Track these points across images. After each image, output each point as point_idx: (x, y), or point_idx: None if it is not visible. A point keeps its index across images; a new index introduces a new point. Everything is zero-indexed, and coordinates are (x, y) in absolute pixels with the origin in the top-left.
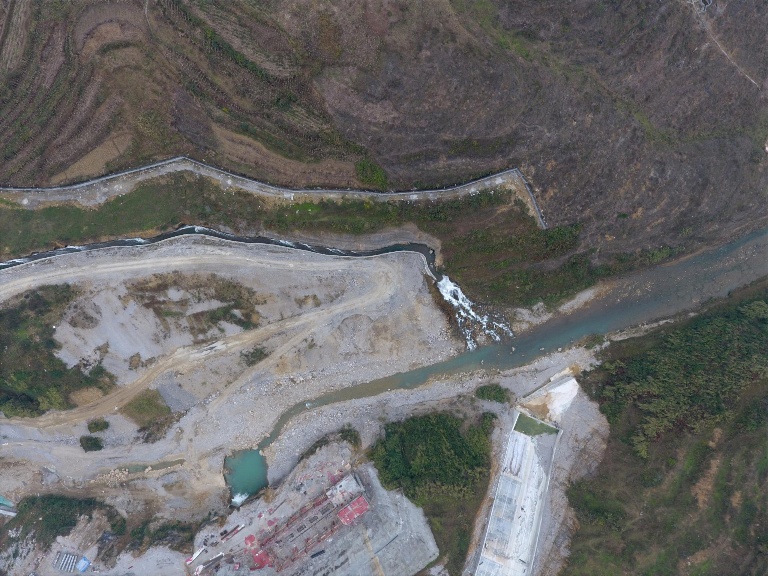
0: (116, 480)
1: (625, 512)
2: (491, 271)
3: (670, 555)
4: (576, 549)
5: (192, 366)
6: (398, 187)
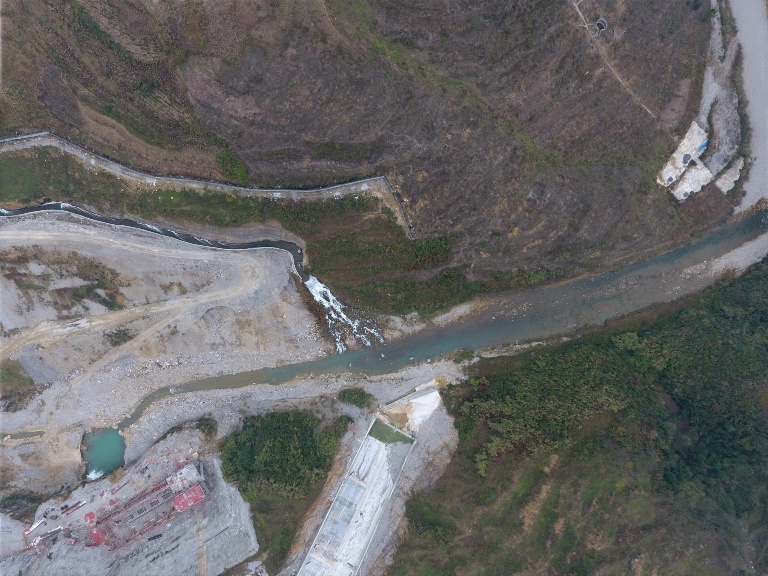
0: None
1: (456, 527)
2: (360, 276)
3: (489, 574)
4: (400, 559)
5: (54, 341)
6: (261, 183)
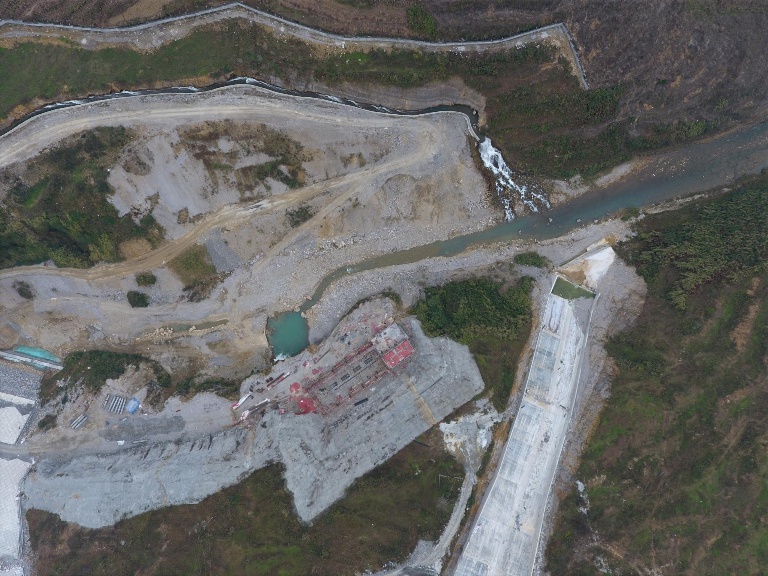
0: (161, 338)
1: (664, 359)
2: (532, 135)
3: (709, 395)
4: (617, 391)
5: (238, 223)
6: (447, 37)
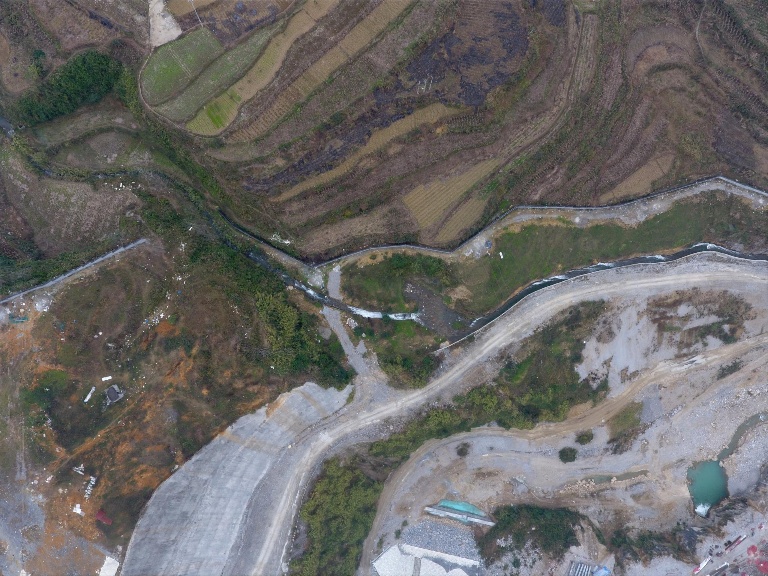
0: (585, 490)
1: None
2: None
3: None
4: None
5: (675, 379)
6: None
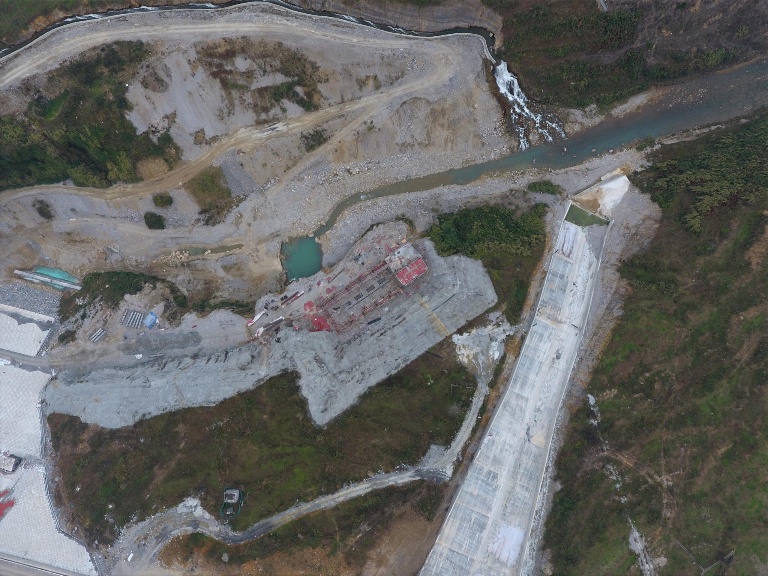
0: (177, 261)
1: (677, 280)
2: (549, 60)
3: (722, 312)
4: (629, 308)
5: (254, 145)
6: None
